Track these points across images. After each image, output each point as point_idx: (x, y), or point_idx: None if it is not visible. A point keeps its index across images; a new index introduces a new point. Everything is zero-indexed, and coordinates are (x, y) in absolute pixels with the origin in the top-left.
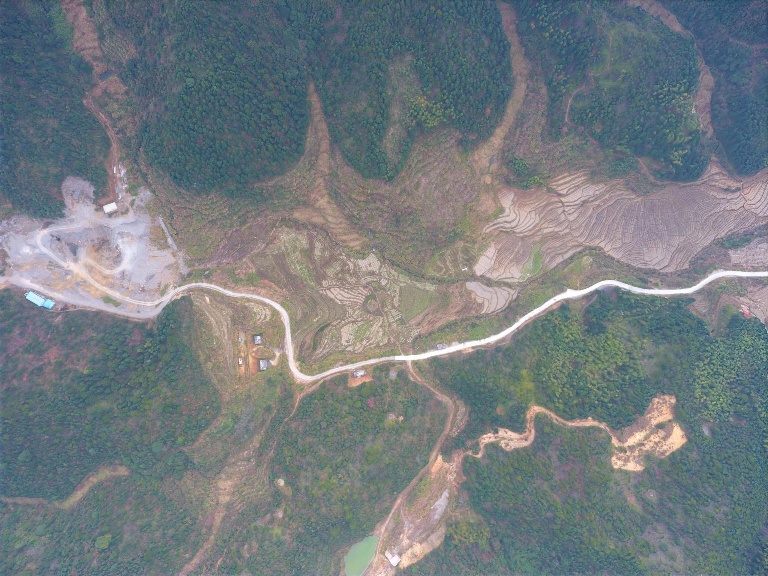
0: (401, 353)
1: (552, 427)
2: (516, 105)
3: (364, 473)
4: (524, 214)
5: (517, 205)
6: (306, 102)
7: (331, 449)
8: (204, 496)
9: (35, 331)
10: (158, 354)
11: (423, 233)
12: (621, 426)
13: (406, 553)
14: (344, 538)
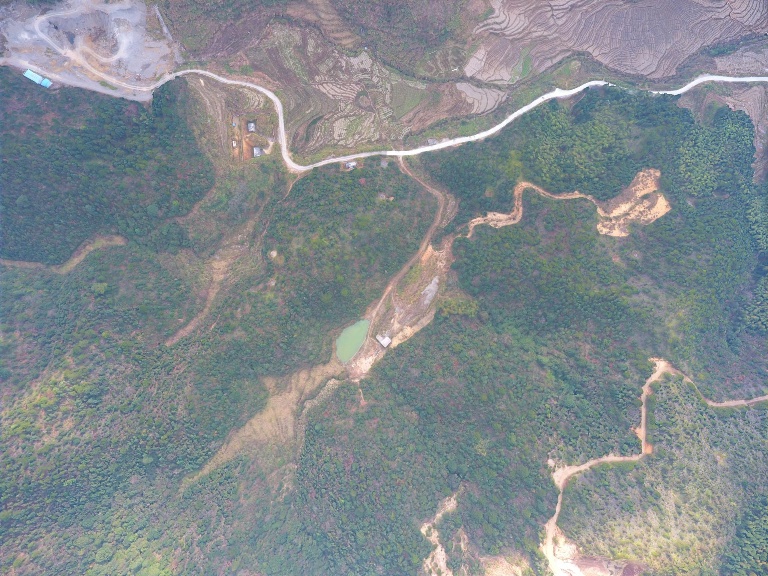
0: (392, 149)
1: (539, 199)
2: None
3: (355, 235)
4: (513, 16)
5: (507, 7)
6: None
7: (322, 215)
8: (198, 272)
9: (33, 99)
10: (153, 124)
11: (414, 28)
12: (607, 198)
13: (397, 336)
14: (336, 315)
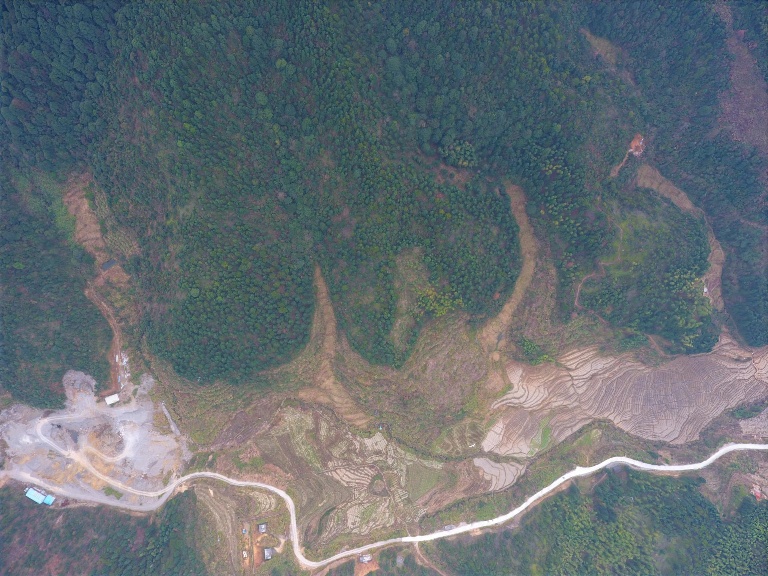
0: (408, 534)
1: None
2: (525, 282)
3: None
4: (533, 389)
5: (525, 380)
6: (312, 288)
7: None
8: None
9: (35, 537)
10: (161, 559)
11: (430, 414)
12: None
13: None
14: None
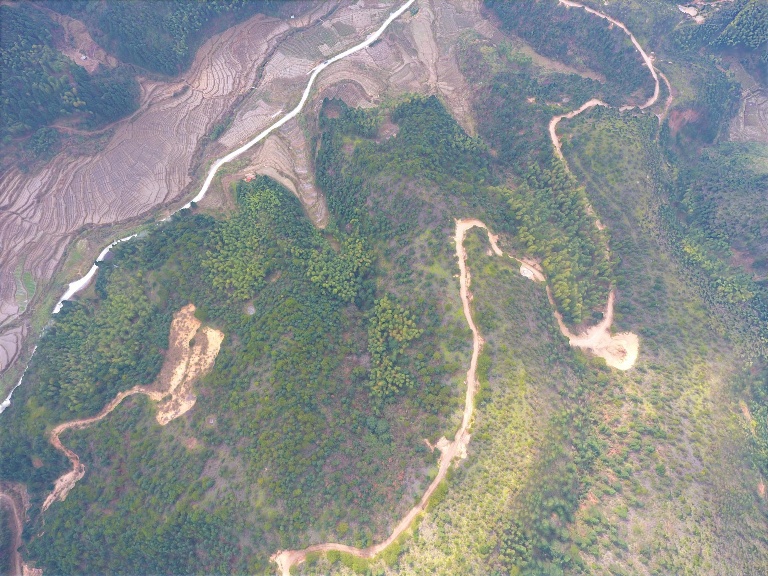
0: None
1: (78, 437)
2: None
3: None
4: None
5: None
6: None
7: None
8: None
9: None
10: None
11: None
12: (154, 376)
13: None
14: None
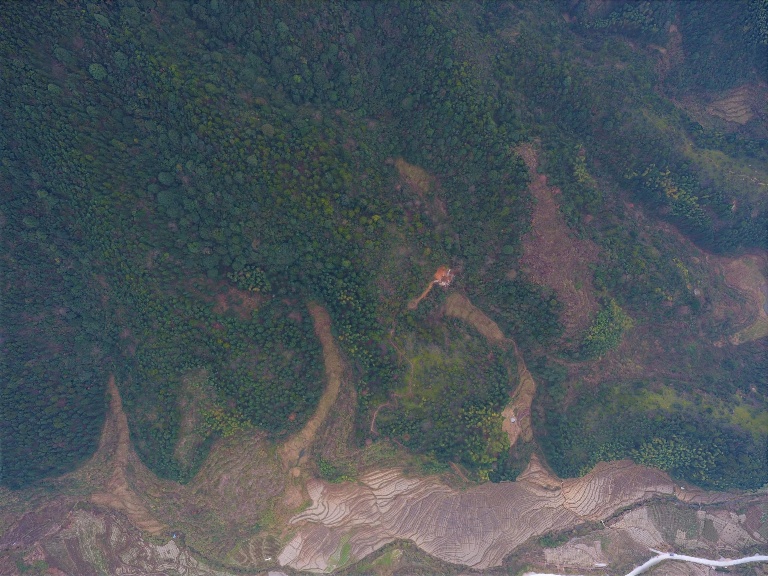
0: None
1: None
2: (329, 401)
3: None
4: (333, 506)
5: (327, 497)
6: (104, 397)
7: None
8: None
9: None
10: None
11: (222, 528)
12: None
13: None
14: None
